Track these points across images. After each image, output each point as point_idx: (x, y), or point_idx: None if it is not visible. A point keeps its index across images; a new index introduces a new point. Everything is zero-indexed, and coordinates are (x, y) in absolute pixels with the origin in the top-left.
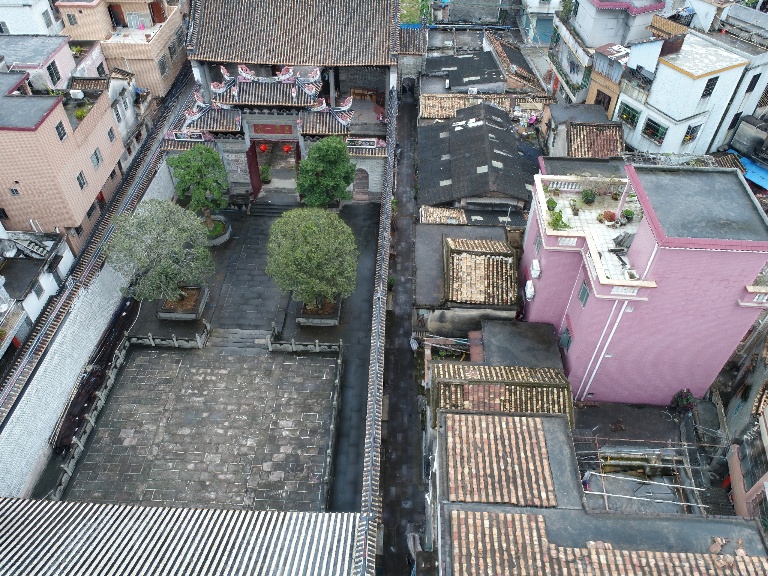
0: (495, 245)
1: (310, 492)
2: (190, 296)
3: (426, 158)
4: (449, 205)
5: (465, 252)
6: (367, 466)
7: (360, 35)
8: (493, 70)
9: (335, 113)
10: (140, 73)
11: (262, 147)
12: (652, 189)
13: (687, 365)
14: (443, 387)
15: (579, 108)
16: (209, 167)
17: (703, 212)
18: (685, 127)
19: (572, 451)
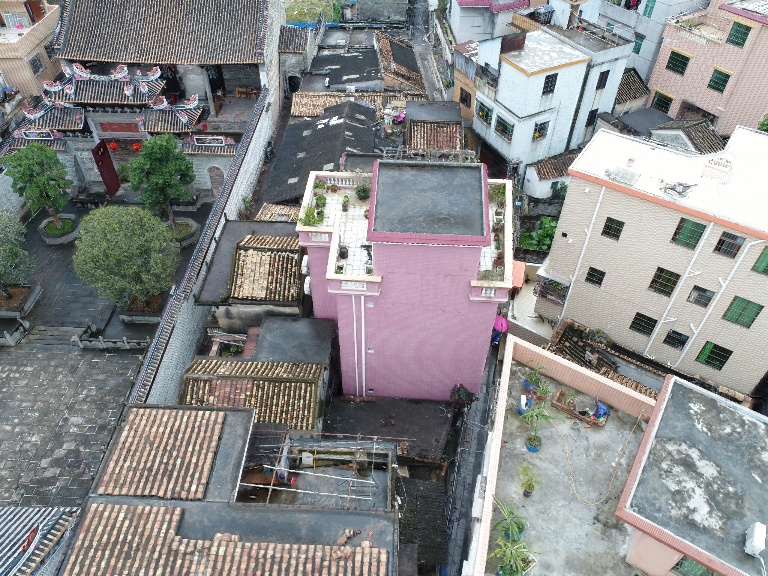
0: (292, 242)
1: (81, 488)
2: (19, 294)
3: (284, 156)
4: (294, 203)
5: (252, 248)
6: None
7: (229, 33)
8: (373, 68)
9: (176, 111)
10: (11, 72)
11: (111, 145)
12: (389, 184)
13: (450, 360)
14: (192, 382)
15: (435, 105)
16: (44, 165)
17: (428, 207)
18: (532, 124)
19: (243, 444)
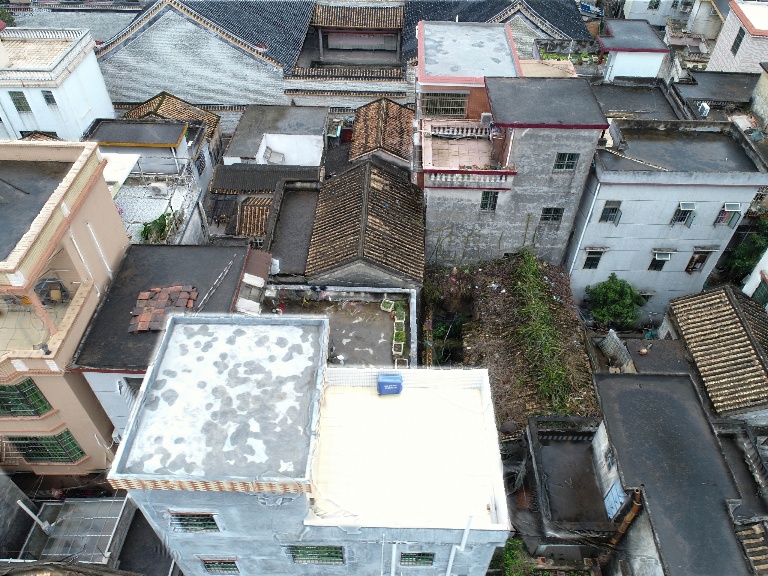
0: None
1: None
2: None
3: None
4: None
5: None
6: (130, 7)
7: None
8: None
9: None
10: None
11: None
12: None
13: None
14: None
15: None
16: None
17: None
18: None
19: None
